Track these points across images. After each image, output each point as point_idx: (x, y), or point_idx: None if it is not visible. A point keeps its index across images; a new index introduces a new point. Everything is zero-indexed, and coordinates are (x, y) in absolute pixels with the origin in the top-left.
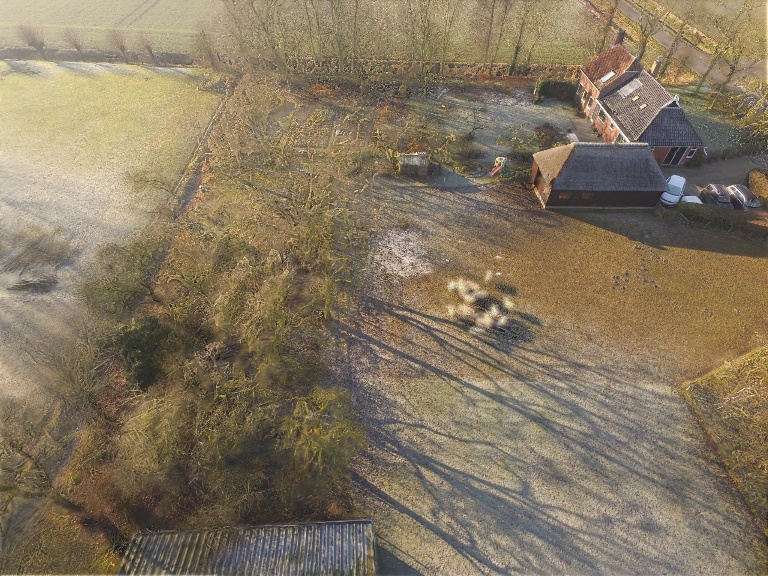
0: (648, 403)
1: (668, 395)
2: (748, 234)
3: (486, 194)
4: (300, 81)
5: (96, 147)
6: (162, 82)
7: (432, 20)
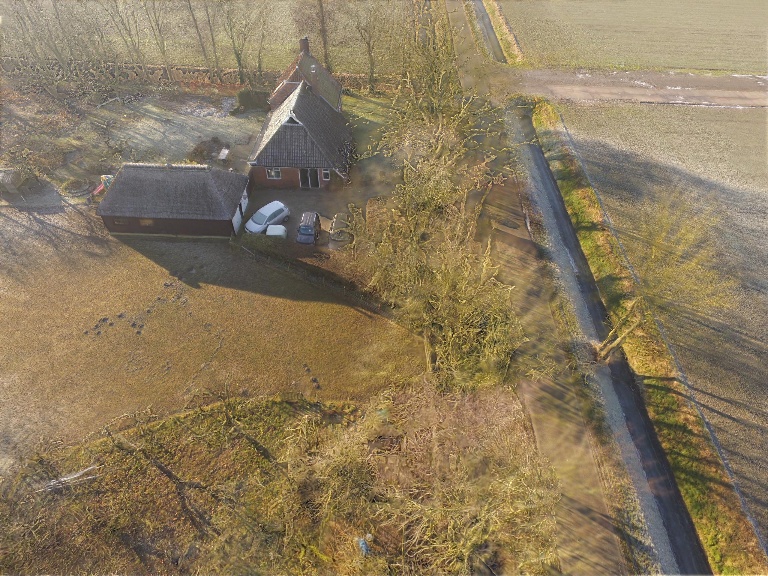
0: None
1: (0, 471)
2: (303, 273)
3: (64, 216)
4: (8, 85)
5: None
6: None
7: None
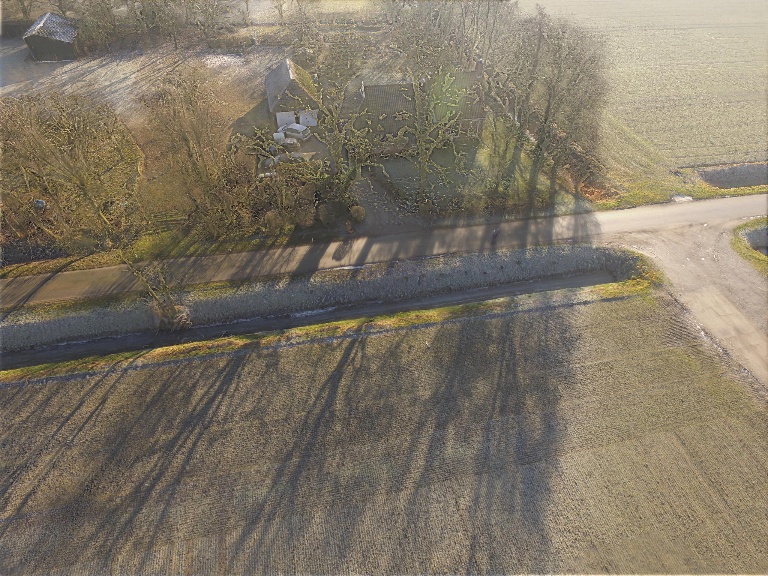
0: (110, 107)
1: None
2: None
3: None
4: None
5: None
6: None
7: (602, 64)
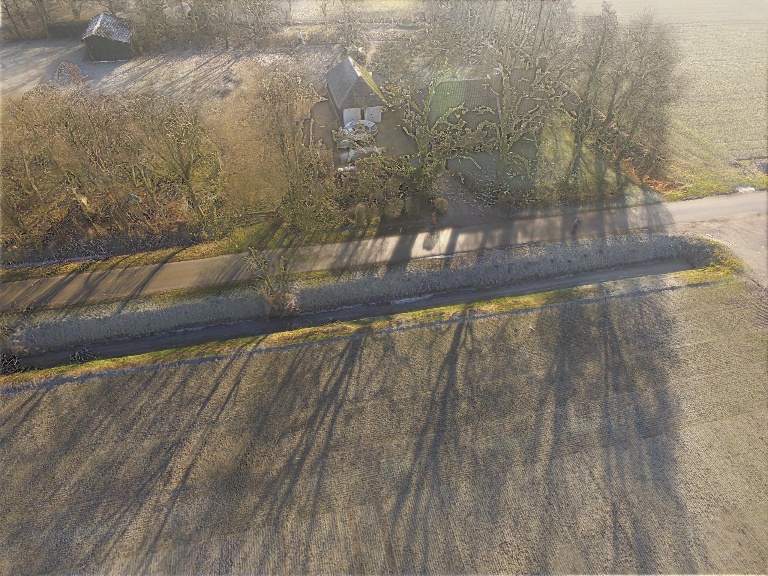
0: None
1: None
2: None
3: None
4: None
5: (340, 3)
6: (417, 3)
7: None
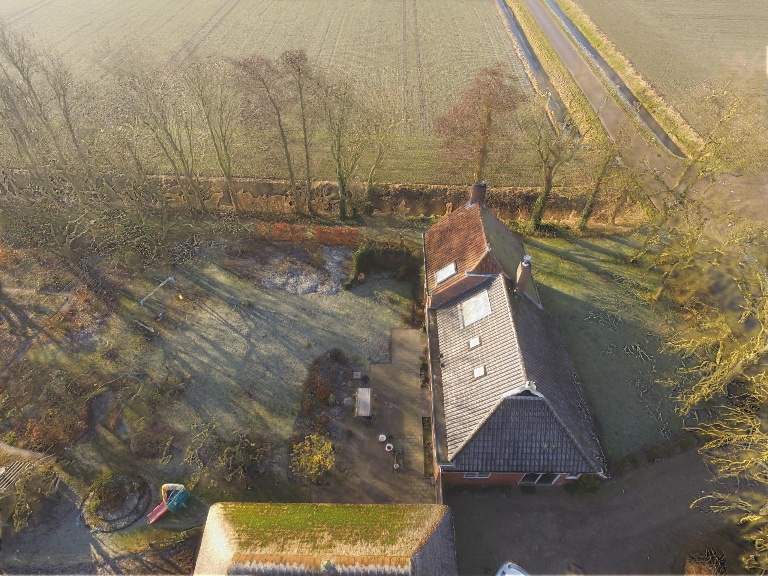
0: None
1: None
2: None
3: None
4: None
5: None
6: None
7: None
